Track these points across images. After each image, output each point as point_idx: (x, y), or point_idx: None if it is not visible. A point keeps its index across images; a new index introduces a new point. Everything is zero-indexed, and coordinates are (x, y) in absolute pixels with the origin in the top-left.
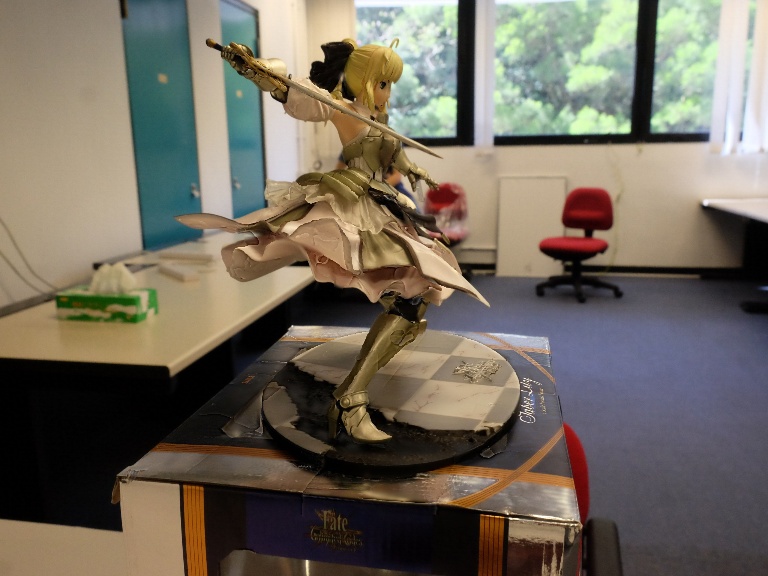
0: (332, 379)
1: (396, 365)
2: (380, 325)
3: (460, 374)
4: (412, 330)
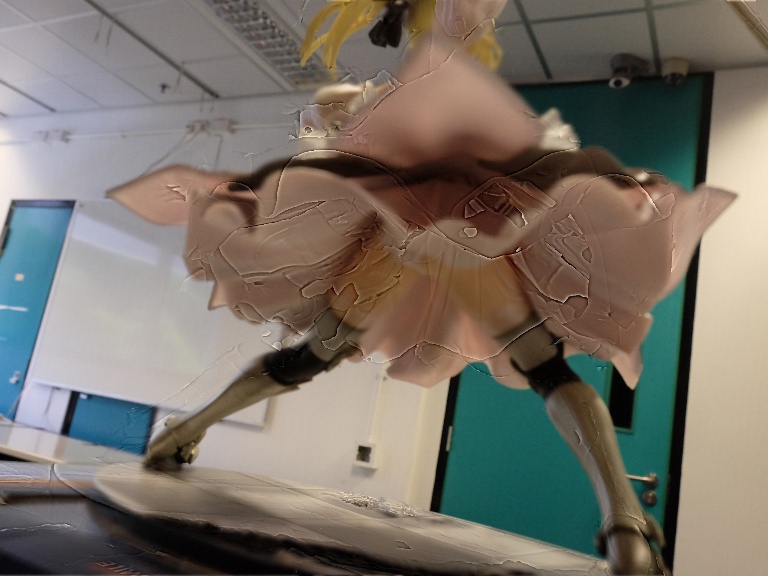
0: (301, 534)
1: (285, 504)
2: (570, 393)
3: (373, 508)
4: (543, 409)
